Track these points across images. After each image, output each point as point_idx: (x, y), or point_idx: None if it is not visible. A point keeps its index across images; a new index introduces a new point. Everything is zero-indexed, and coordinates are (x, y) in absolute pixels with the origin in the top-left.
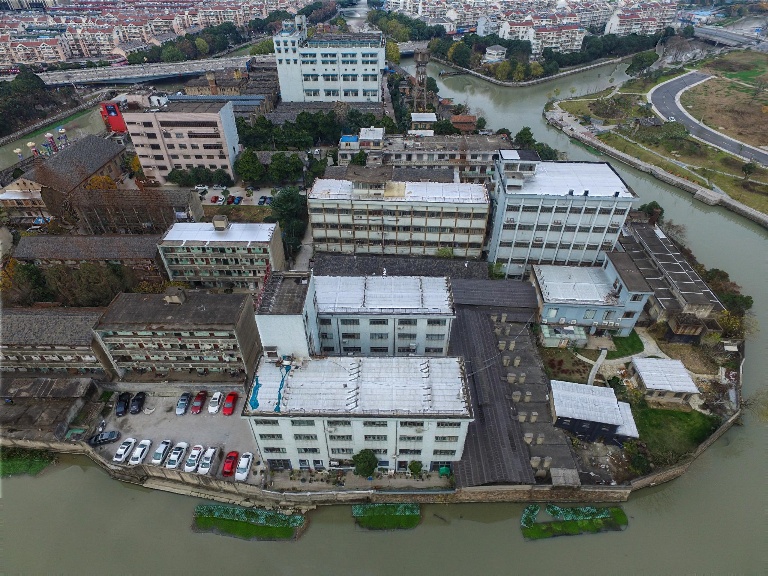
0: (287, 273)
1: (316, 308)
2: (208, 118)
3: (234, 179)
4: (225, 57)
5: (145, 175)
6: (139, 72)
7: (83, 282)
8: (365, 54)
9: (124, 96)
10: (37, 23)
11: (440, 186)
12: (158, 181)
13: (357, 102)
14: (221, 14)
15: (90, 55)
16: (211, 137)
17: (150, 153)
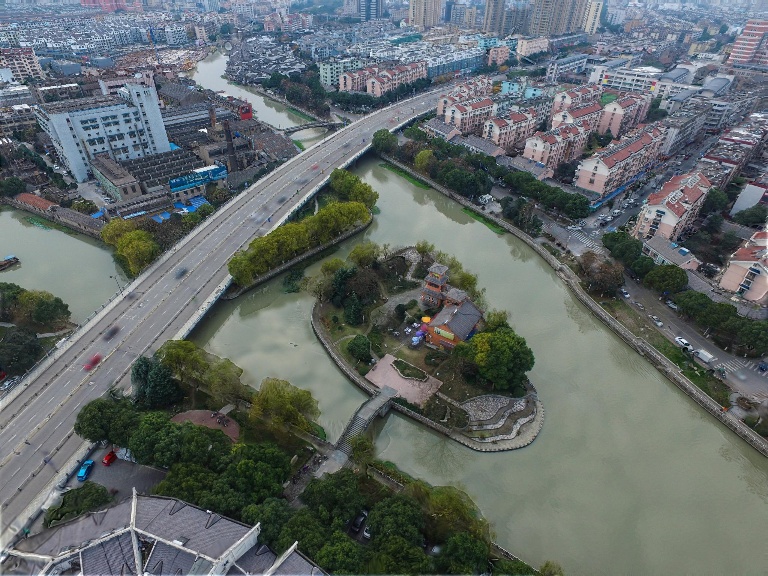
0: (6, 69)
1: (3, 80)
2: None
3: None
4: None
5: None
6: (359, 129)
7: (80, 77)
8: None
9: None
10: None
11: None
12: None
13: None
14: None
15: None
16: None
17: None
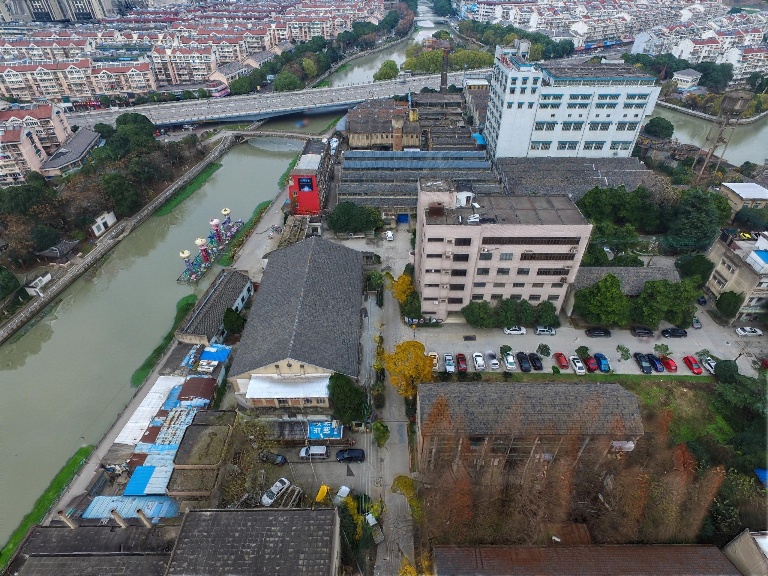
0: None
1: None
2: (569, 232)
3: (559, 313)
4: None
5: (421, 310)
6: (257, 106)
7: None
8: (631, 95)
9: (312, 160)
10: (102, 39)
11: None
12: (441, 319)
13: (603, 158)
14: (306, 26)
15: (179, 81)
16: (557, 259)
17: (445, 281)
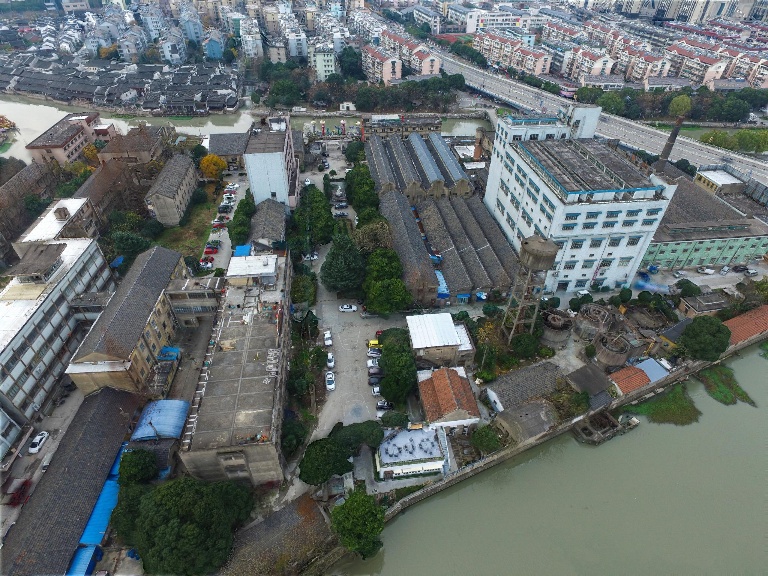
0: None
1: None
2: None
3: None
4: (657, 128)
5: None
6: None
7: (14, 188)
8: (546, 198)
9: (388, 116)
10: None
11: (7, 328)
12: None
13: (513, 254)
14: None
15: None
16: None
17: None
